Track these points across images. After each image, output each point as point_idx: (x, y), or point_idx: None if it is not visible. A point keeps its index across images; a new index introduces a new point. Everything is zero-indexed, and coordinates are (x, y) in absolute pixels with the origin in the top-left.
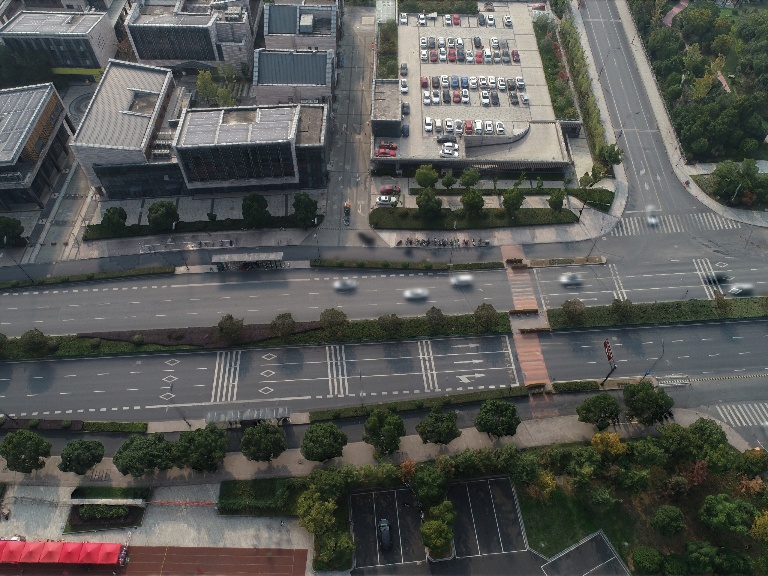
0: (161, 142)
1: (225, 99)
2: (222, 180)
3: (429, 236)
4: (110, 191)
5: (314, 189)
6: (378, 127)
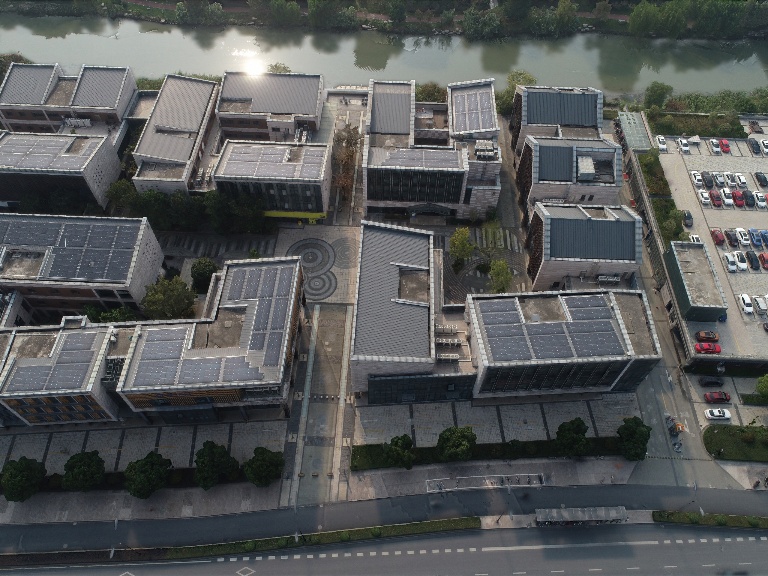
0: (445, 341)
1: None
2: (520, 390)
3: None
4: (374, 398)
5: (619, 393)
6: (694, 312)
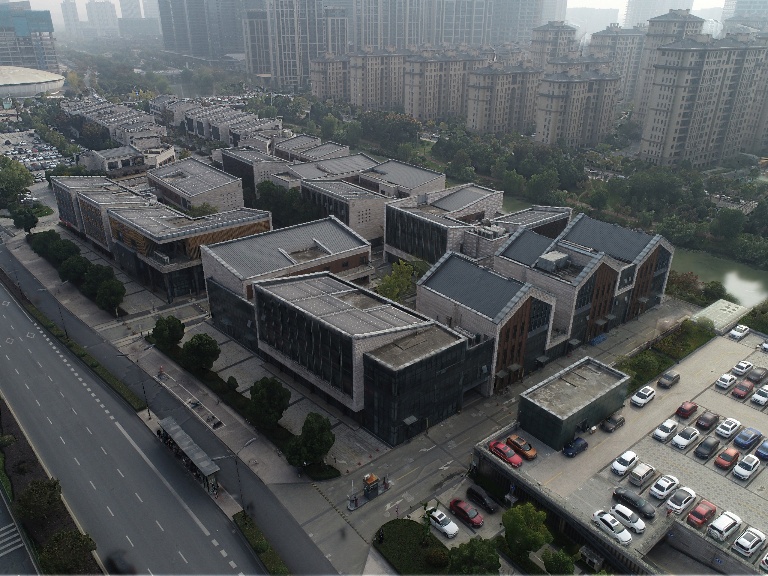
0: None
1: (390, 291)
2: (287, 356)
3: None
4: (214, 314)
5: (377, 438)
6: (528, 413)
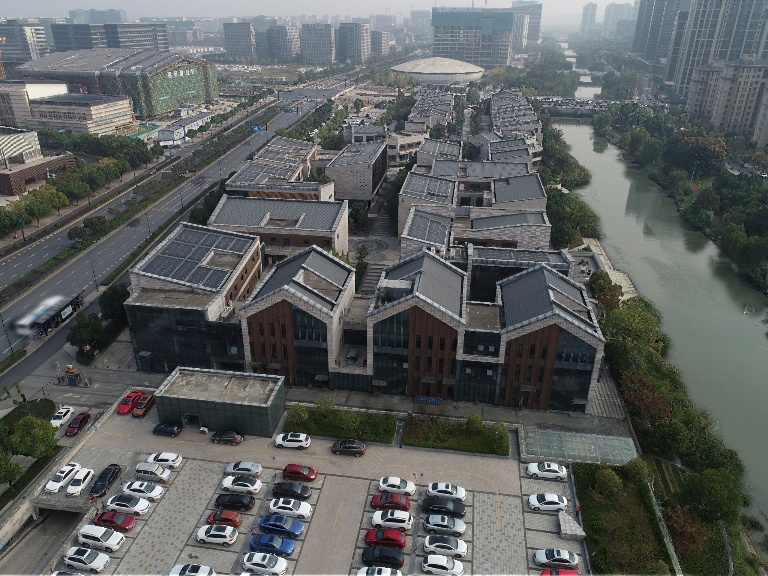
0: None
1: None
2: None
3: None
4: None
5: None
6: None
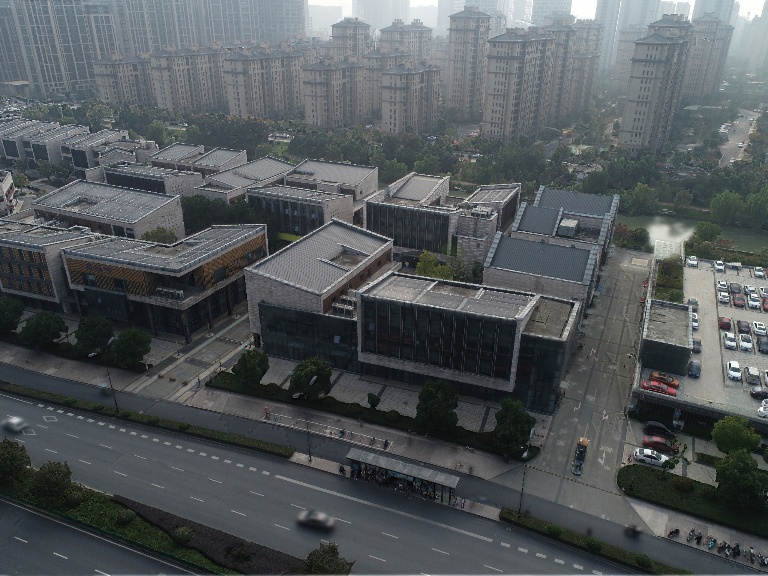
0: (348, 298)
1: None
2: (405, 360)
3: (737, 540)
4: (267, 342)
5: (532, 411)
6: (651, 352)
